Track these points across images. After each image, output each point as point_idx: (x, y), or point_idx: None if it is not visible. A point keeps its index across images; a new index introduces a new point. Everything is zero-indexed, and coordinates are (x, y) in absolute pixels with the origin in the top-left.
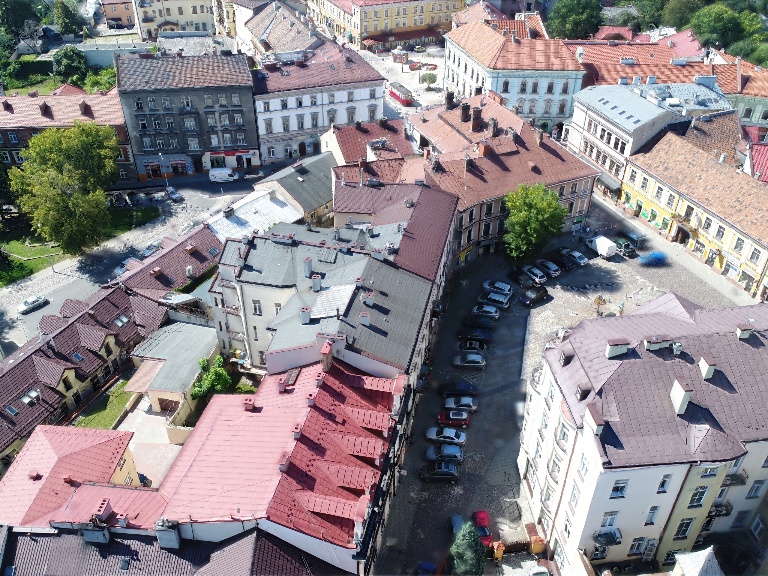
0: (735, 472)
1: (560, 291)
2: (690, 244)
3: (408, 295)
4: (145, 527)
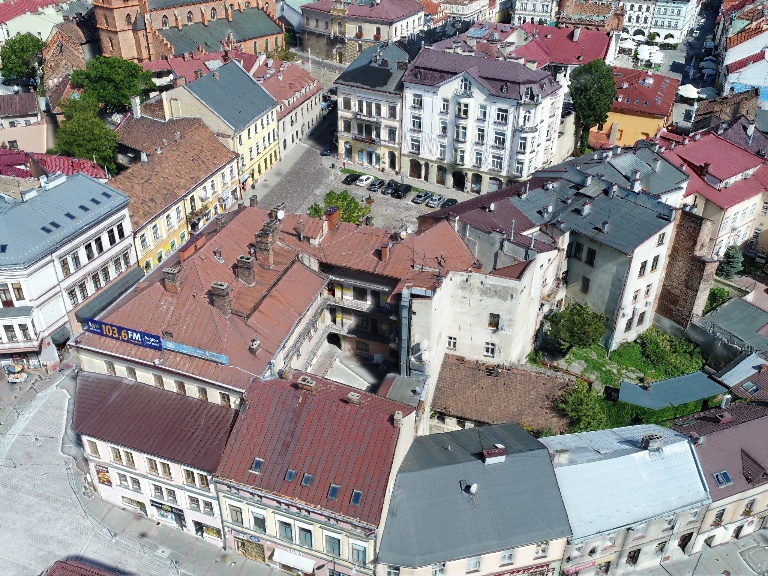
0: None
1: None
2: None
3: None
4: None
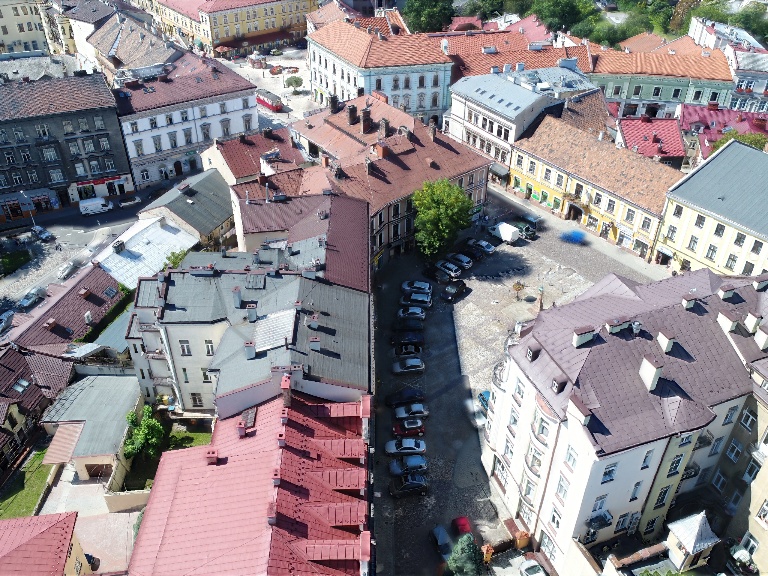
0: (700, 435)
1: (476, 282)
2: (583, 220)
3: (349, 311)
4: None
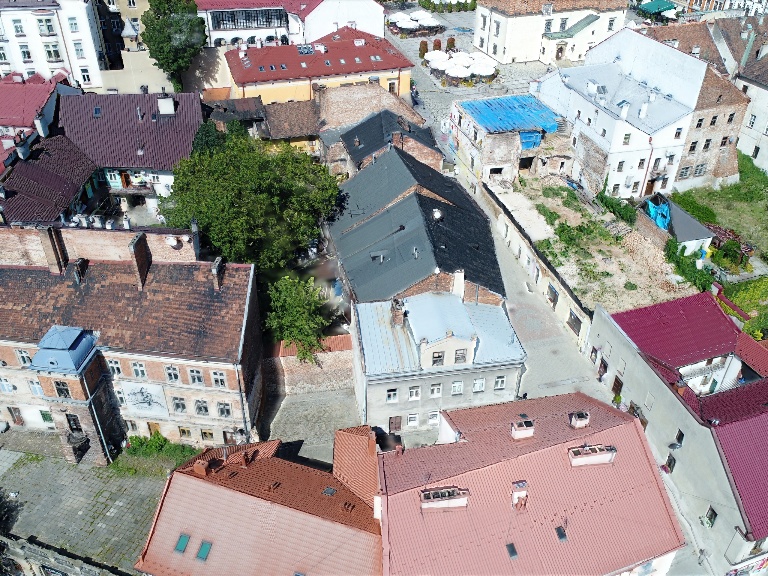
0: None
1: None
2: None
3: None
4: (31, 134)
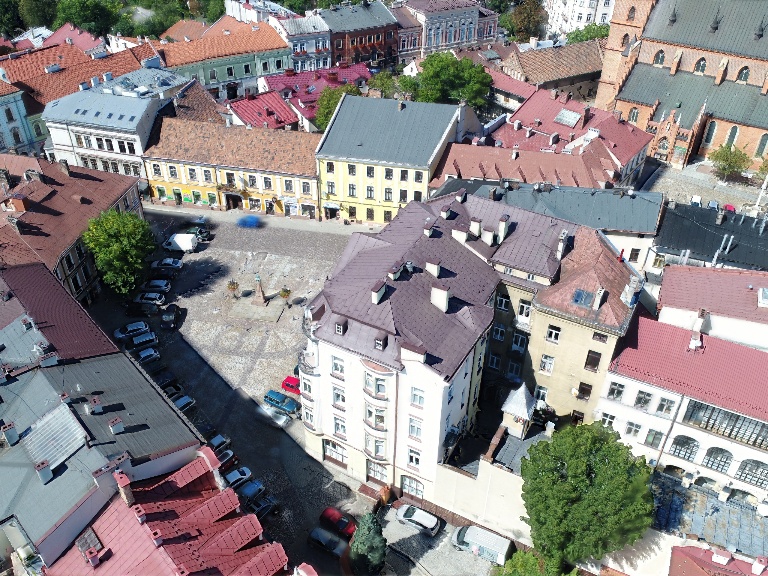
0: None
1: (185, 300)
2: (245, 205)
3: (118, 379)
4: None
